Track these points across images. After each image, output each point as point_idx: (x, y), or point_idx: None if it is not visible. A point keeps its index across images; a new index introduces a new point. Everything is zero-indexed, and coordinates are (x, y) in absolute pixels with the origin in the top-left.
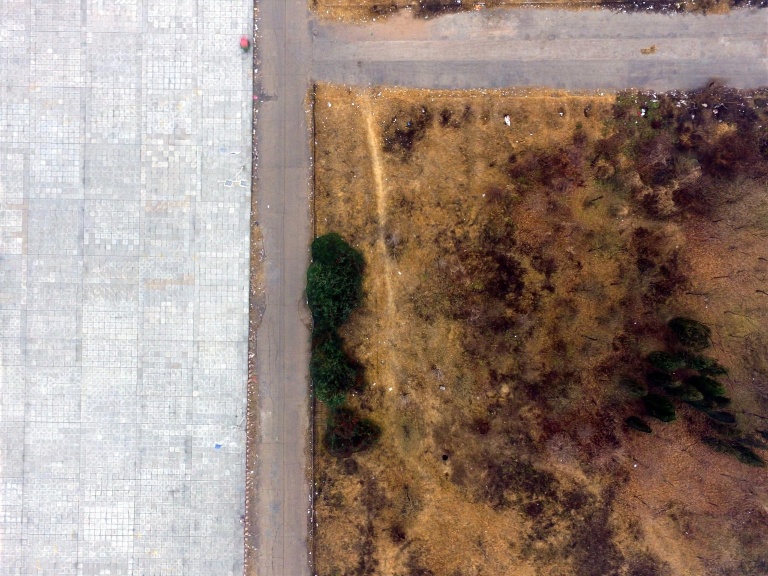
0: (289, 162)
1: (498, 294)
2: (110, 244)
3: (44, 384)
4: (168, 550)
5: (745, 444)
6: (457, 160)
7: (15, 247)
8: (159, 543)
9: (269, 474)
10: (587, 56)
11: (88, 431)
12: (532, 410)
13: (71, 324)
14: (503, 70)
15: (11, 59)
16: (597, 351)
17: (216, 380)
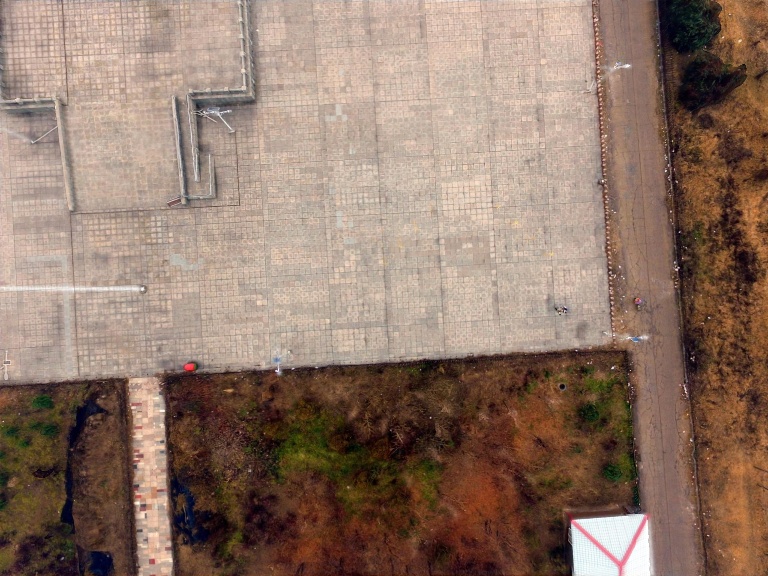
0: None
1: None
2: None
3: (391, 63)
4: (528, 219)
5: None
6: None
7: None
8: (519, 213)
9: (623, 137)
10: None
11: (439, 107)
12: None
13: (413, 1)
14: None
15: None
16: None
17: (563, 46)
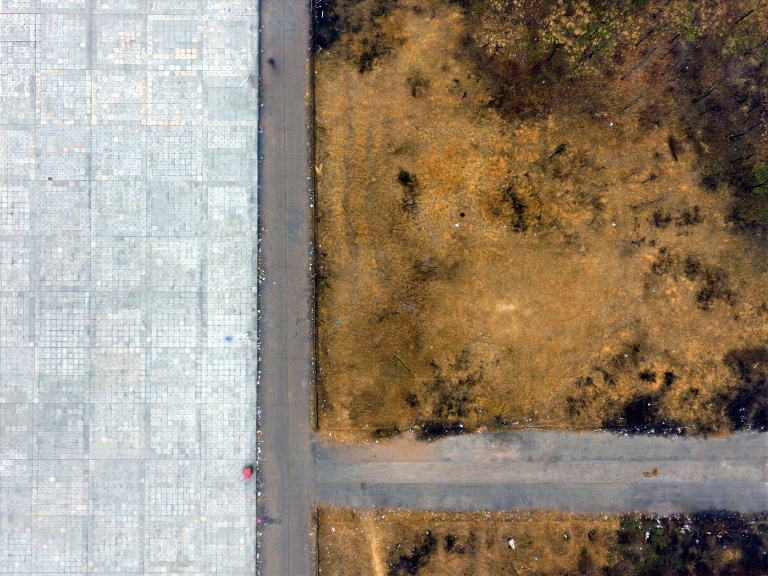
0: None
1: None
2: None
3: None
4: None
5: None
6: None
7: None
8: None
9: None
10: (590, 479)
11: None
12: None
13: None
14: (507, 492)
15: (13, 488)
16: None
17: None
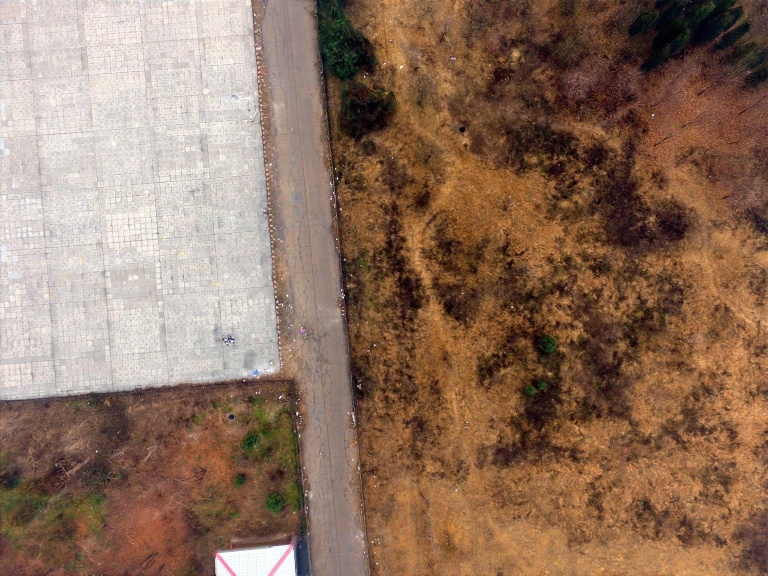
0: None
1: None
2: None
3: (53, 96)
4: (194, 250)
5: (761, 61)
6: None
7: None
8: (184, 244)
9: (288, 165)
10: None
11: (102, 139)
12: (545, 71)
13: (74, 33)
14: None
15: None
16: (604, 5)
17: (225, 76)
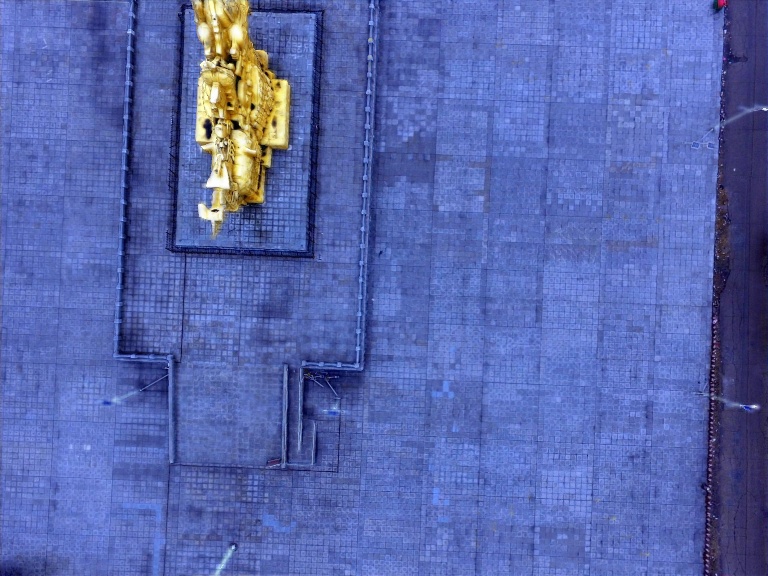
0: (757, 125)
1: None
2: (573, 204)
3: (503, 344)
4: (627, 517)
5: None
6: None
7: (477, 205)
8: (618, 509)
9: (731, 442)
10: None
11: (547, 393)
12: None
13: (532, 284)
14: None
15: (478, 16)
16: None
17: (678, 345)
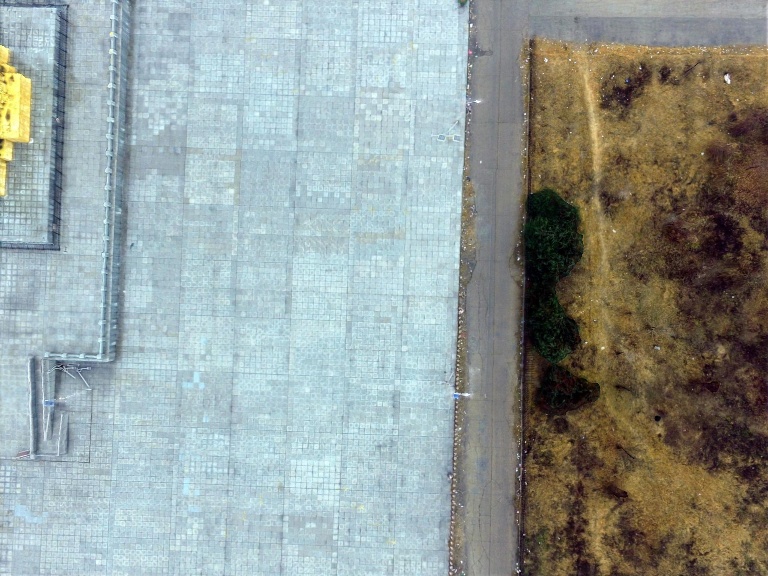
0: (503, 118)
1: (715, 254)
2: (322, 197)
3: (253, 335)
4: (374, 505)
5: None
6: (676, 118)
7: (227, 198)
8: (365, 498)
9: (477, 431)
10: None
11: (296, 384)
12: (749, 372)
13: (281, 276)
14: (723, 28)
15: (227, 10)
16: None
17: (425, 335)
